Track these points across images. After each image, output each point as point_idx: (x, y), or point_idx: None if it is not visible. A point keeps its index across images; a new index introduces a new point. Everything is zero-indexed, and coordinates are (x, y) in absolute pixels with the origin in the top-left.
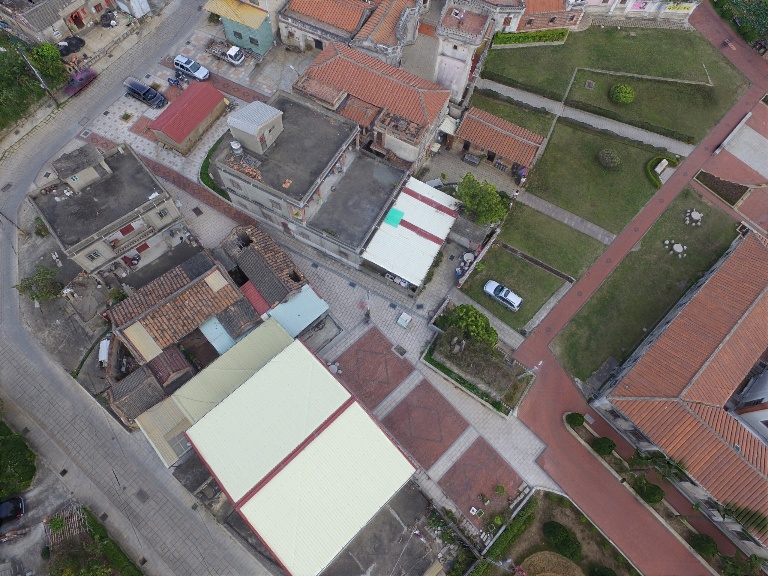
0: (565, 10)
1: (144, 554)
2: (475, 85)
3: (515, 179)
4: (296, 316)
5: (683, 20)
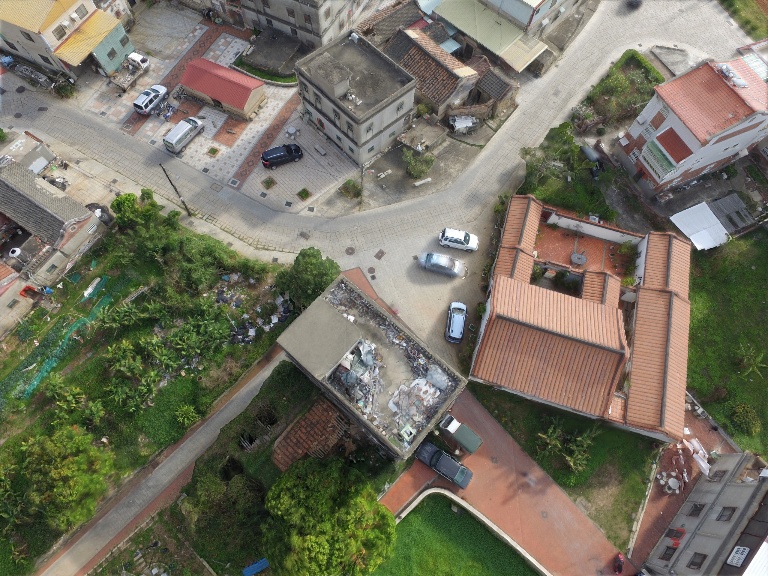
0: None
1: (589, 87)
2: None
3: None
4: (429, 2)
5: None
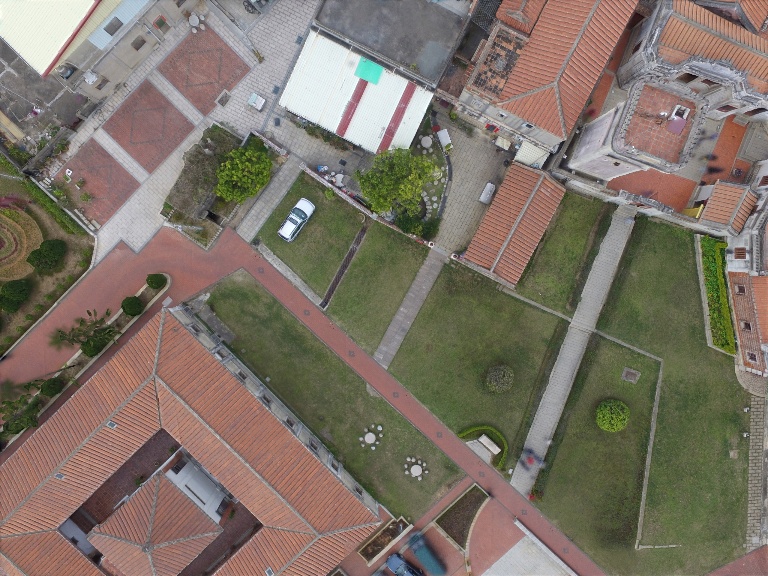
0: (762, 342)
1: None
2: (620, 205)
3: (461, 250)
4: None
5: (767, 537)
